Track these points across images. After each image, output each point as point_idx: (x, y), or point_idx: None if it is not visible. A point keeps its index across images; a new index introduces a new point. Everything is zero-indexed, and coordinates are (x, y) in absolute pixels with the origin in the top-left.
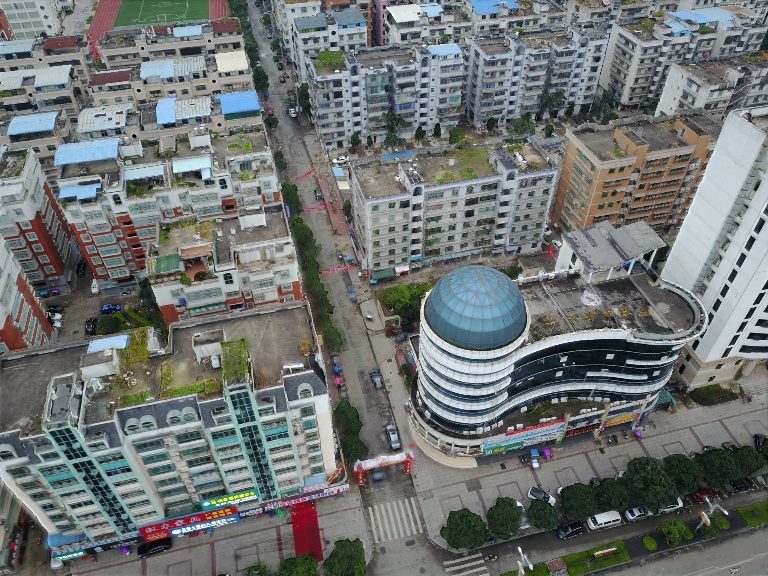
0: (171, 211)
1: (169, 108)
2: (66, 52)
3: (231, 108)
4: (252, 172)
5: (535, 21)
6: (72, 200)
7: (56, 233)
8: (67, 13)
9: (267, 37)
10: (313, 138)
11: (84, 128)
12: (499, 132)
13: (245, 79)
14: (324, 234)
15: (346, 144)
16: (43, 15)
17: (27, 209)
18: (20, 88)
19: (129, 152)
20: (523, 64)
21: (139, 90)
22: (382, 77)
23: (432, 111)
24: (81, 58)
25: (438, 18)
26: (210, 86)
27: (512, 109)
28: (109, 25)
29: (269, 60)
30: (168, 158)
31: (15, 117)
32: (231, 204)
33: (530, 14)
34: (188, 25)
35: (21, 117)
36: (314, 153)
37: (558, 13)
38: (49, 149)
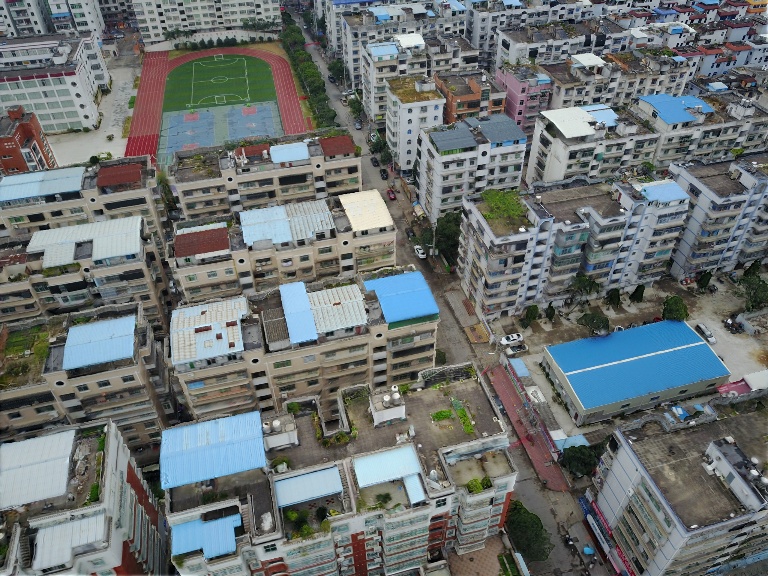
0: (347, 538)
1: (304, 312)
2: (127, 186)
3: (397, 311)
4: (475, 463)
5: (735, 128)
6: (193, 552)
7: (146, 548)
8: (104, 93)
9: (356, 128)
10: (459, 296)
11: (182, 356)
12: (711, 287)
13: (387, 237)
14: (528, 489)
15: (512, 312)
16: (79, 104)
17: (111, 556)
18: (72, 263)
19: (278, 441)
20: (758, 204)
21: (242, 260)
22: (581, 234)
23: (630, 266)
24: (147, 195)
25: (612, 127)
26: (339, 249)
27: (728, 256)
28: (157, 110)
29: (366, 163)
30: (341, 448)
31: (72, 328)
32: (439, 515)
33: (728, 119)
34: (283, 138)
35: (81, 328)
36: (468, 324)
37: (765, 118)
38: (124, 380)
